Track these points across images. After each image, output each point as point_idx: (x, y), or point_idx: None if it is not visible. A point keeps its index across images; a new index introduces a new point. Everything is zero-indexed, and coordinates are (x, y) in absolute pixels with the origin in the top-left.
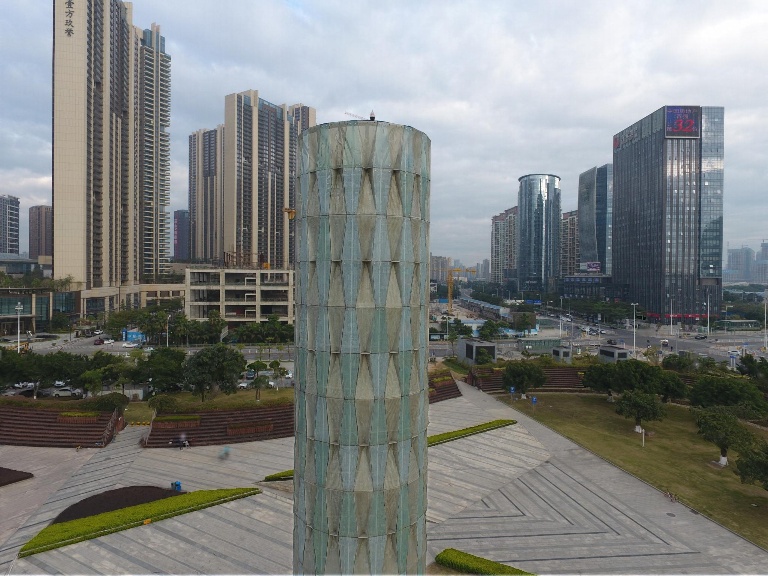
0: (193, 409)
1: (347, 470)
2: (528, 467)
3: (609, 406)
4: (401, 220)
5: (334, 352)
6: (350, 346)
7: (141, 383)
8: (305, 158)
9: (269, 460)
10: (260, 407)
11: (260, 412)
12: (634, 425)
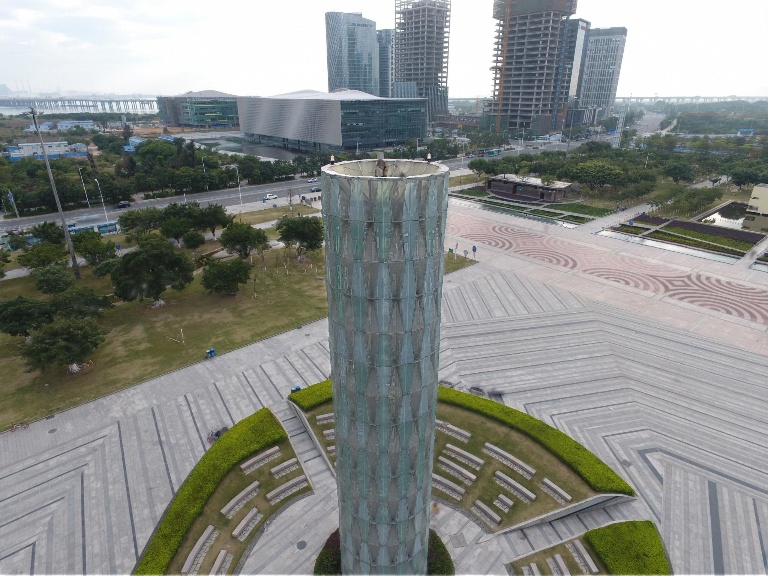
0: None
1: None
2: None
3: None
4: None
5: None
6: None
7: None
8: None
9: None
10: None
11: None
12: None
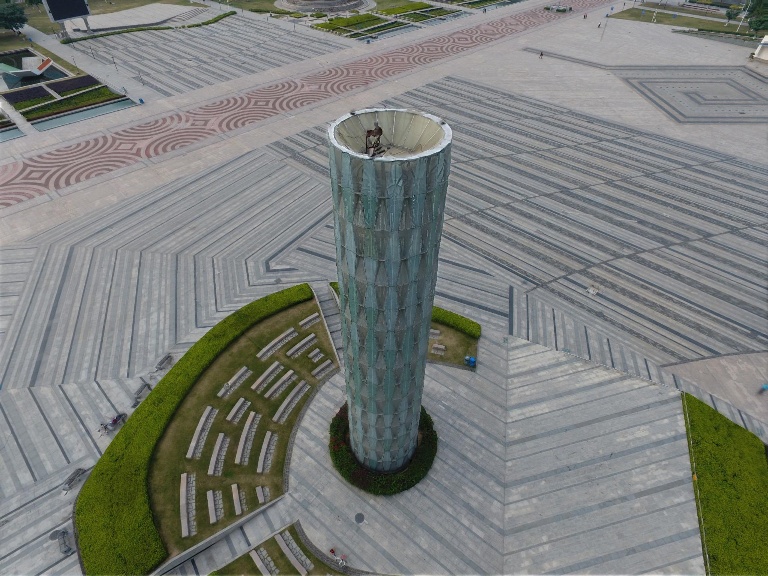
0: None
1: None
2: None
3: None
4: None
5: None
6: None
7: None
8: None
9: None
10: None
11: None
12: None
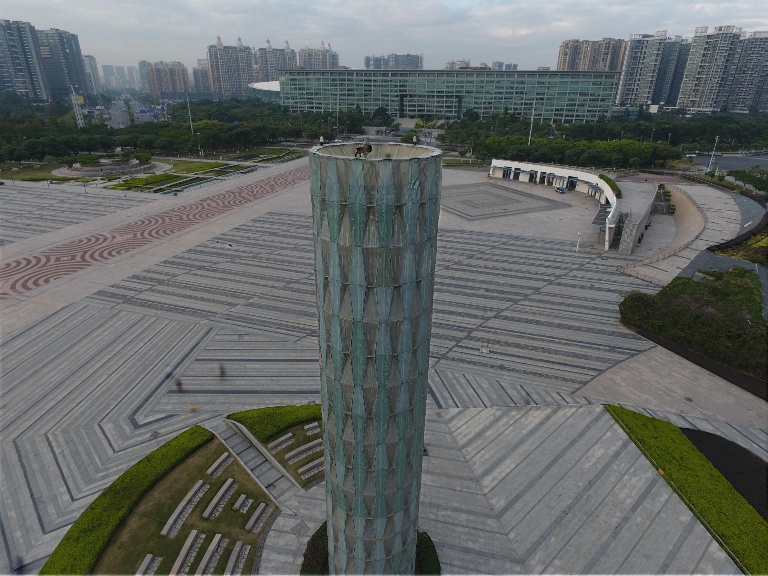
0: None
1: None
2: None
3: None
4: None
5: None
6: None
7: None
8: None
9: None
10: None
11: None
12: None
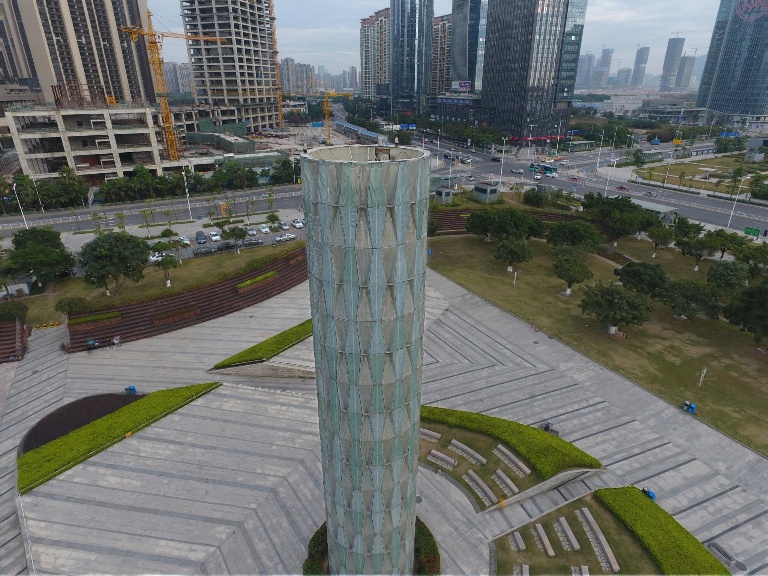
0: (108, 306)
1: (376, 428)
2: (433, 317)
3: (486, 247)
4: (415, 244)
5: (364, 355)
6: (376, 348)
7: (21, 276)
8: (322, 188)
9: (209, 346)
10: (179, 293)
11: (181, 298)
12: (506, 264)
